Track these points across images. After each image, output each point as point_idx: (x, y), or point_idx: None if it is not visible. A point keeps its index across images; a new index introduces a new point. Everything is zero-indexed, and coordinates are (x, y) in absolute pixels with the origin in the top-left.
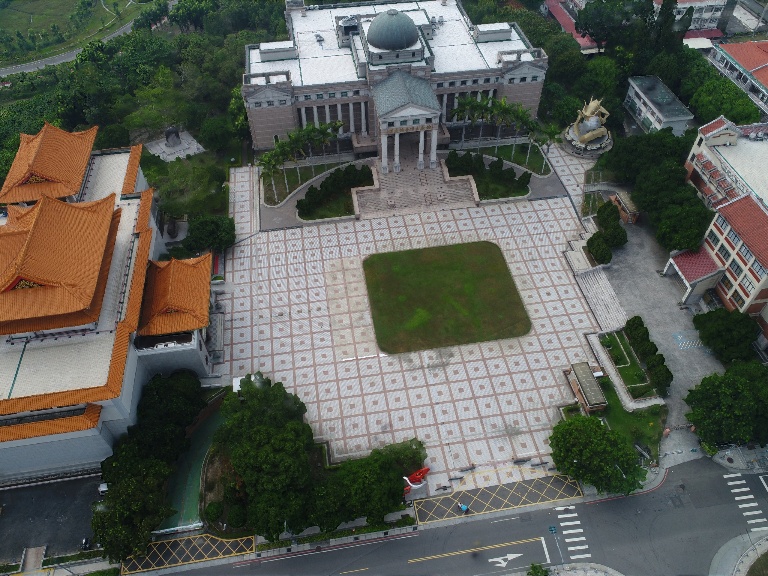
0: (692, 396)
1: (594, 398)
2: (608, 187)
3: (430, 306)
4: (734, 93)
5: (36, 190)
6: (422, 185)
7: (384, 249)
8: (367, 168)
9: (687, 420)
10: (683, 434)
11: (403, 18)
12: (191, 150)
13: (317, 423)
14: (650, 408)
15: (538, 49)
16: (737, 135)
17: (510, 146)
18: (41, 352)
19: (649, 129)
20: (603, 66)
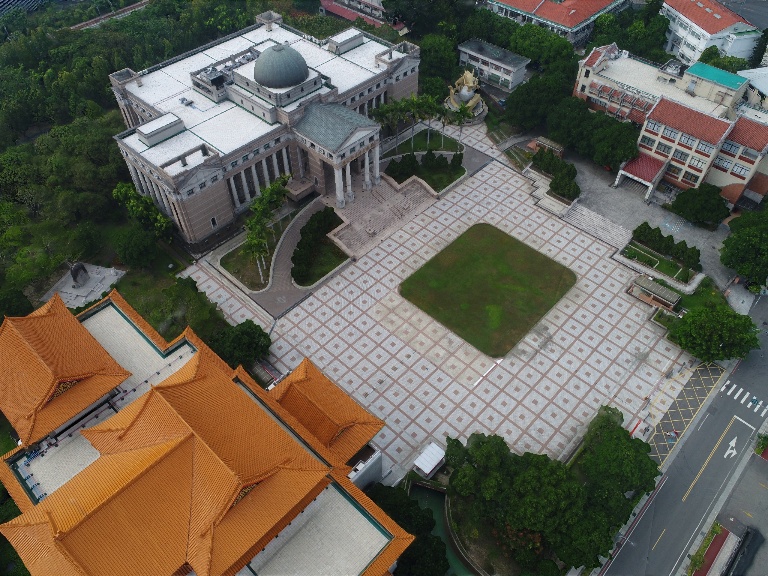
0: (736, 257)
1: (672, 297)
2: (517, 139)
3: (492, 299)
4: (544, 32)
5: (71, 400)
6: (381, 203)
7: (406, 274)
8: (333, 208)
9: (726, 278)
10: (734, 289)
11: (291, 50)
12: (108, 279)
13: (511, 450)
14: (703, 283)
15: (403, 43)
16: (608, 59)
17: None
18: (278, 561)
19: (499, 82)
20: (439, 42)
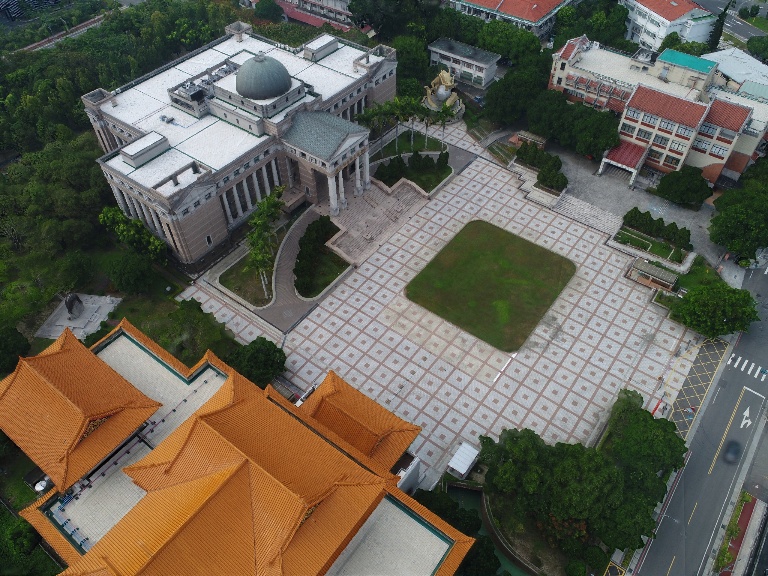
0: (726, 234)
1: (670, 278)
2: (498, 135)
3: (497, 295)
4: (510, 28)
5: (102, 438)
6: (374, 207)
7: (409, 277)
8: (329, 217)
9: (717, 255)
10: (725, 265)
11: (273, 60)
12: (104, 307)
13: None
14: (696, 262)
15: (379, 46)
16: (581, 51)
17: (395, 141)
18: None
19: (471, 80)
20: (410, 44)
